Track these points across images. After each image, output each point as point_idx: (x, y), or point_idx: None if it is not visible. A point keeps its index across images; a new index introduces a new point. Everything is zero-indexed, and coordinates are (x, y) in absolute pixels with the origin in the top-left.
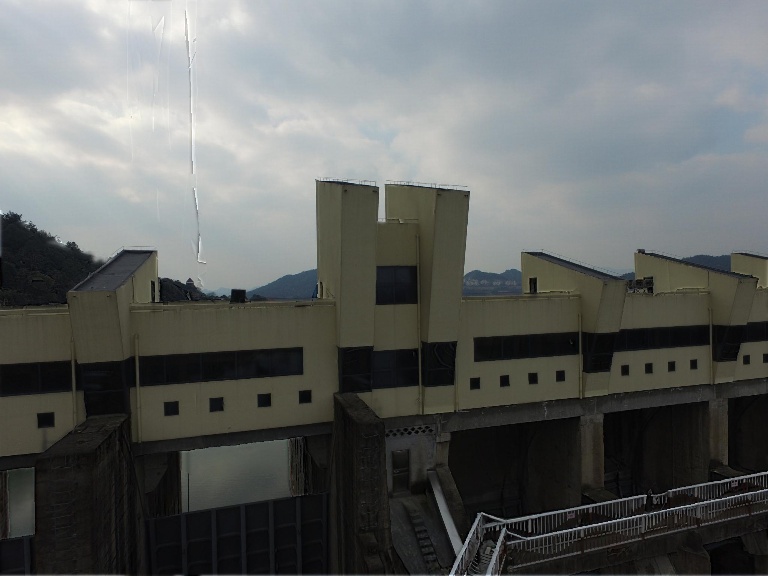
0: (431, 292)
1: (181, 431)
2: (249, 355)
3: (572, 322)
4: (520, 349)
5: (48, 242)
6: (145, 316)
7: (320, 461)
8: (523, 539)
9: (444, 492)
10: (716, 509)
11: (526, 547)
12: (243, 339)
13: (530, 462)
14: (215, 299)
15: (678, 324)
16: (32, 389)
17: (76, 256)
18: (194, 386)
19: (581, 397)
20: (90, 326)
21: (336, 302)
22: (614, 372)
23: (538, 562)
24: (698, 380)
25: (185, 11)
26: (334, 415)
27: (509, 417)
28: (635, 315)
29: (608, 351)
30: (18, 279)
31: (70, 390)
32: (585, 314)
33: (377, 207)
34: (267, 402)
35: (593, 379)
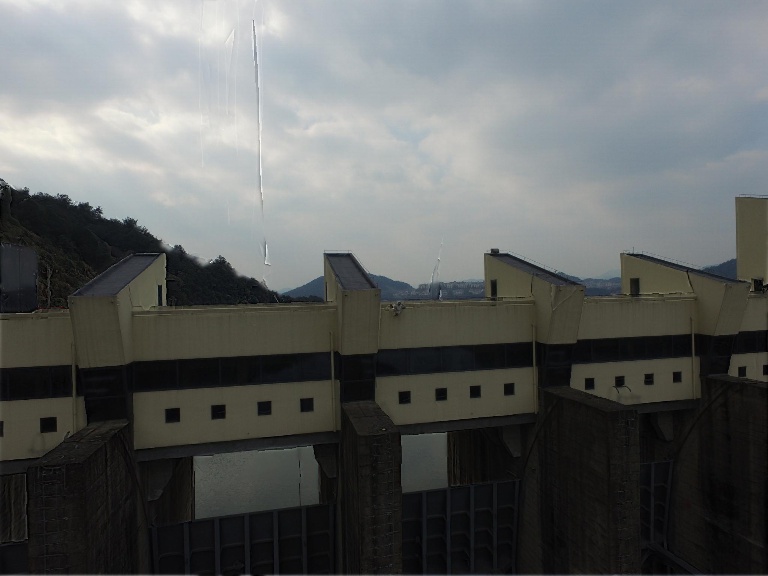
0: None
1: None
2: None
3: None
4: None
5: (163, 245)
6: None
7: None
8: None
9: None
10: None
11: None
12: None
13: None
14: (296, 299)
15: None
16: (666, 354)
17: (188, 258)
18: (754, 355)
19: None
20: (730, 308)
21: None
22: None
23: None
24: None
25: (253, 23)
26: None
27: None
28: None
29: None
30: None
31: (688, 356)
32: None
33: None
34: None
35: None
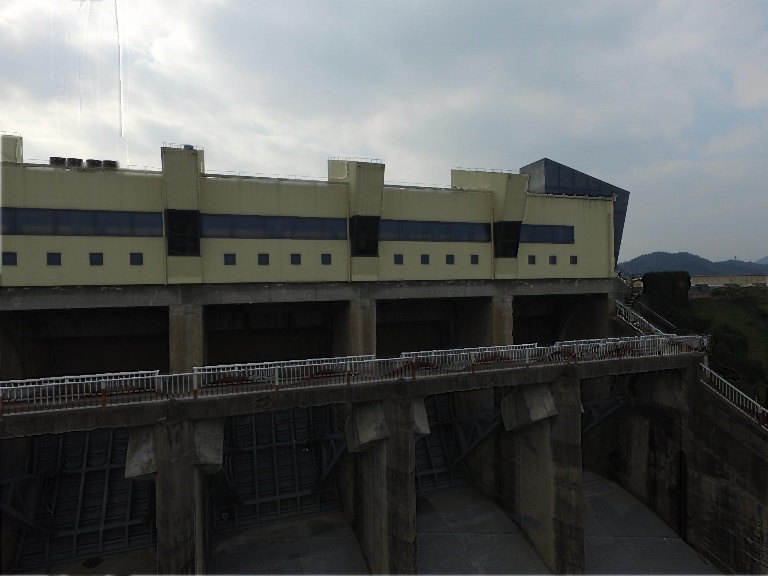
0: None
1: None
2: None
3: None
4: None
5: None
6: None
7: None
8: None
9: None
10: None
11: None
12: None
13: None
14: None
15: (108, 208)
16: None
17: None
18: None
19: None
20: None
21: None
22: None
23: None
24: (145, 279)
25: None
26: None
27: None
28: (29, 191)
29: None
30: None
31: None
32: None
33: None
34: None
35: None
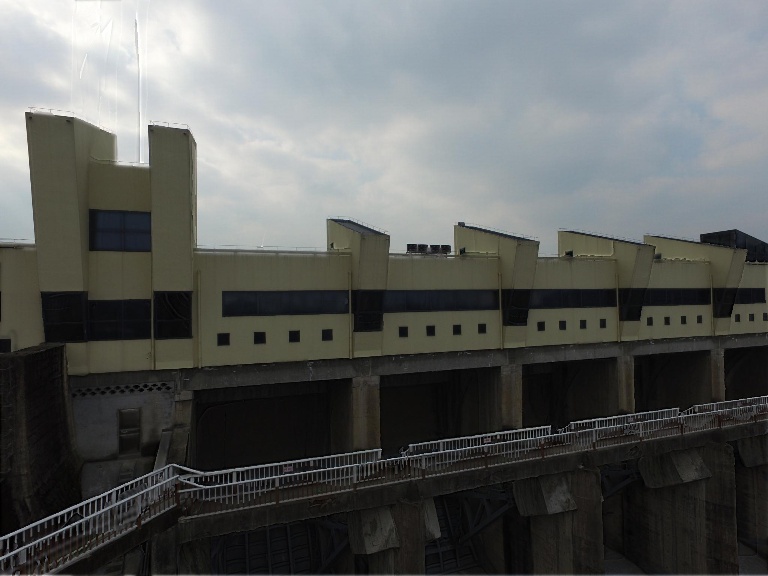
0: (152, 236)
1: None
2: None
3: (342, 280)
4: (281, 306)
5: None
6: None
7: None
8: (199, 487)
9: (169, 451)
10: (446, 460)
11: (204, 496)
12: None
13: (331, 434)
14: None
15: (464, 287)
16: None
17: None
18: None
19: (351, 357)
20: None
21: None
22: (390, 333)
23: (219, 513)
24: (487, 344)
25: (135, 15)
26: None
27: (267, 376)
28: (415, 276)
29: (377, 310)
30: None
31: None
32: (354, 271)
33: (74, 139)
34: None
35: (363, 338)
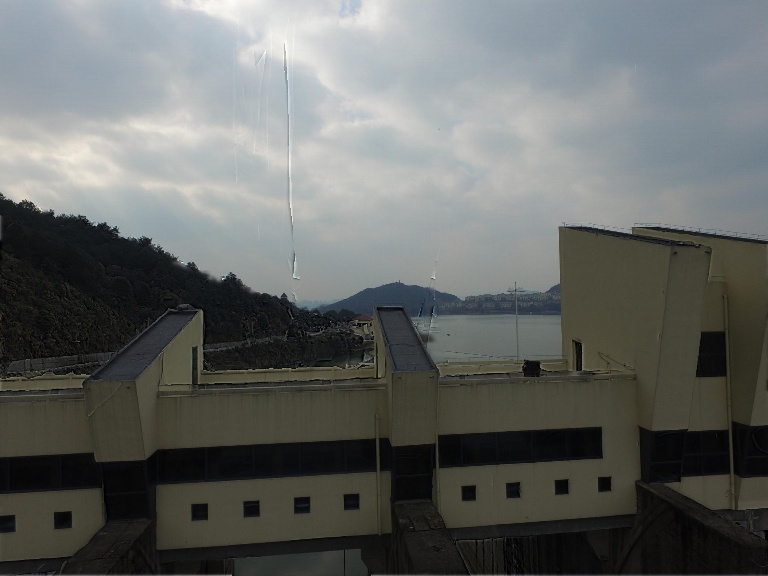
0: (759, 367)
1: (478, 518)
2: (544, 435)
3: None
4: None
5: (173, 263)
6: (443, 391)
7: (601, 552)
8: None
9: None
10: None
11: None
12: (539, 417)
13: None
14: (313, 315)
15: None
16: (337, 468)
17: (196, 276)
18: (490, 469)
19: None
20: (409, 408)
21: (639, 376)
22: None
23: None
24: None
25: (284, 44)
26: (638, 507)
27: None
28: None
29: None
30: (152, 298)
31: (373, 470)
32: None
33: (708, 270)
34: (564, 489)
35: None
